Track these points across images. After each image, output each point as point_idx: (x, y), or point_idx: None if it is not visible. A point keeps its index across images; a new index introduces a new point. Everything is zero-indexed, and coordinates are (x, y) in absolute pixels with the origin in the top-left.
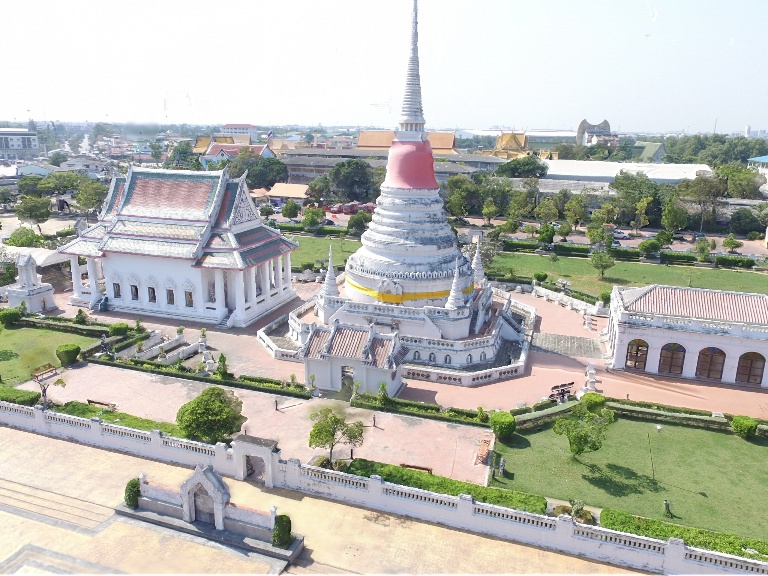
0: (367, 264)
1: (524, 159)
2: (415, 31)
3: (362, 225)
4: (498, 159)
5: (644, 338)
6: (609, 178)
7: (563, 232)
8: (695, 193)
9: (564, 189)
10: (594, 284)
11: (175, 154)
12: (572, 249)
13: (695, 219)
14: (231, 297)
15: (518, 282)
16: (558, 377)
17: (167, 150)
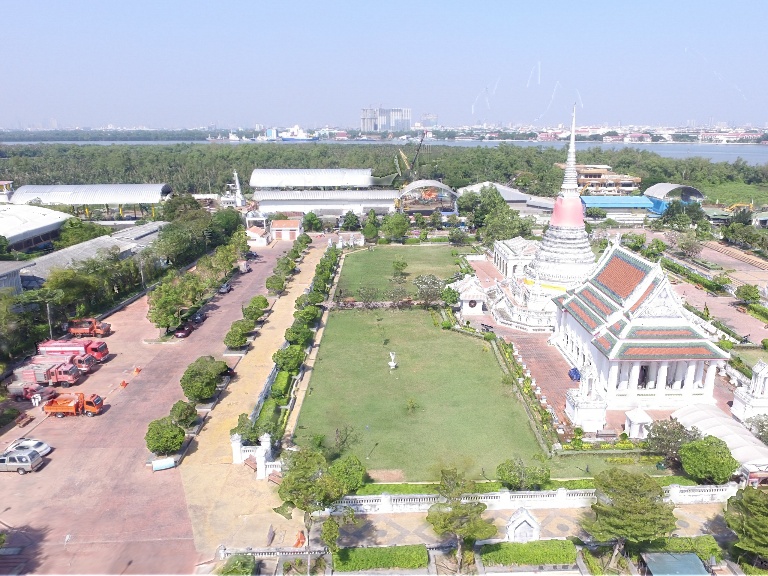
0: None
1: None
2: None
3: None
4: None
5: None
6: (20, 236)
7: None
8: None
9: (149, 248)
10: None
11: None
12: None
13: None
14: None
15: None
16: None
17: None
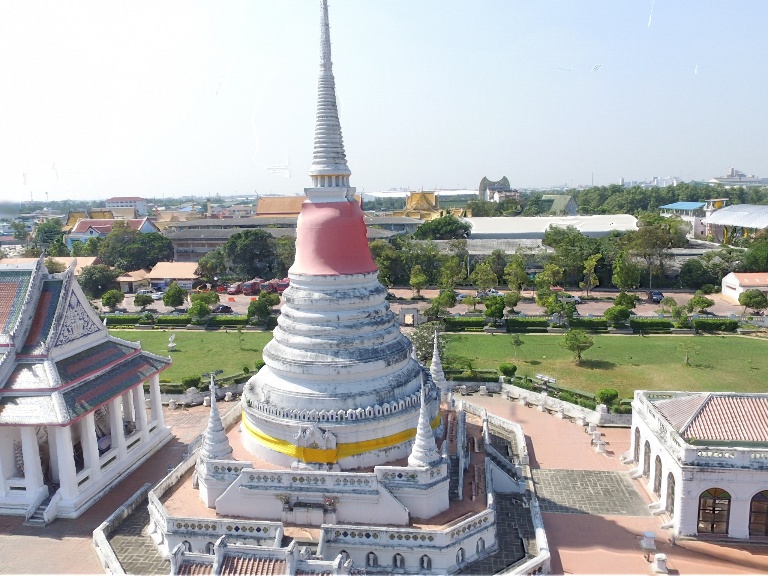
0: (275, 399)
1: (445, 219)
2: (325, 38)
3: (266, 311)
4: (412, 220)
5: (723, 486)
6: (536, 234)
7: (511, 302)
8: (640, 246)
9: (497, 250)
10: (574, 373)
11: (39, 234)
12: (527, 323)
13: (643, 274)
14: (56, 463)
15: (480, 380)
16: (608, 571)
17: (31, 230)
